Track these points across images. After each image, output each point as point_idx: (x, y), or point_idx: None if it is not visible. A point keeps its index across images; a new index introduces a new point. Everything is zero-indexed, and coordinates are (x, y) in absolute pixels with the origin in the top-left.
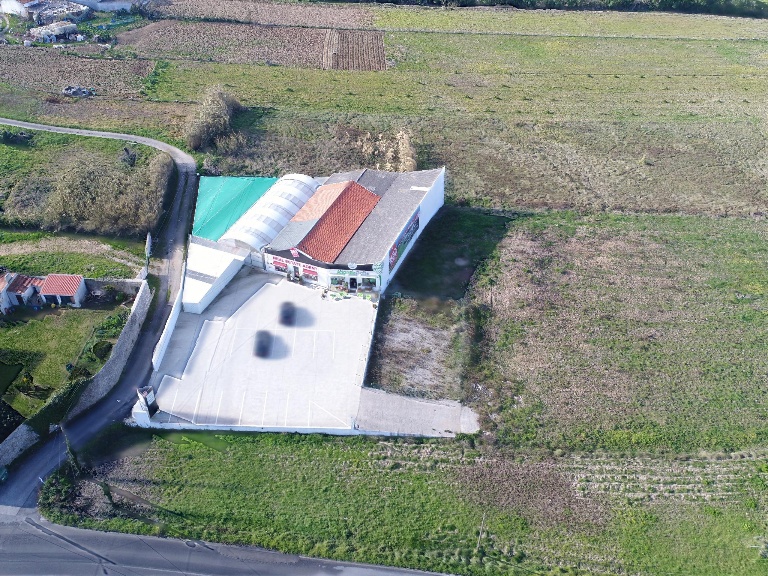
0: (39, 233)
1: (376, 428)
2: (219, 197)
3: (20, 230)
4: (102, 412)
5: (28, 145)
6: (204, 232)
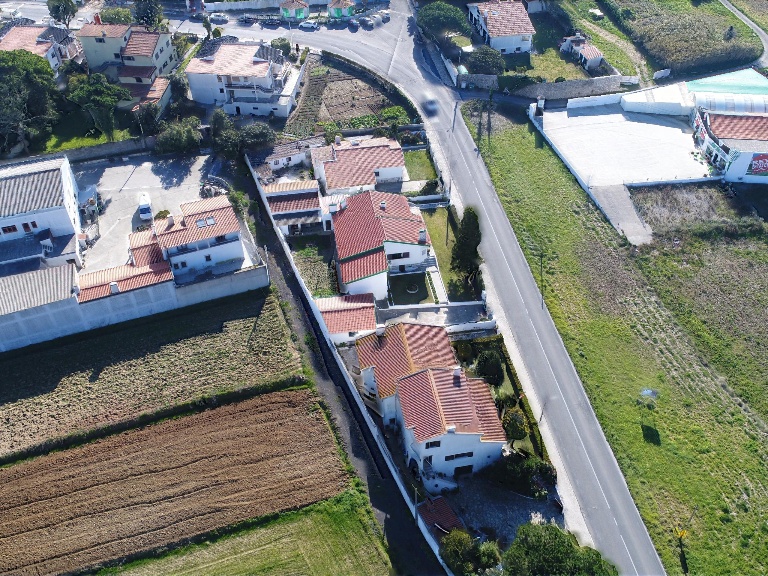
0: (628, 37)
1: (597, 196)
2: (737, 80)
3: (624, 32)
4: (527, 101)
5: (700, 4)
6: (693, 85)
